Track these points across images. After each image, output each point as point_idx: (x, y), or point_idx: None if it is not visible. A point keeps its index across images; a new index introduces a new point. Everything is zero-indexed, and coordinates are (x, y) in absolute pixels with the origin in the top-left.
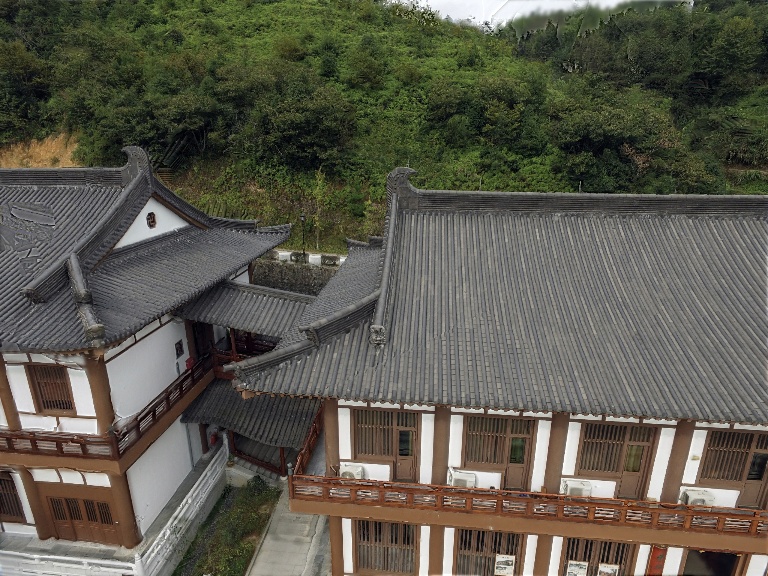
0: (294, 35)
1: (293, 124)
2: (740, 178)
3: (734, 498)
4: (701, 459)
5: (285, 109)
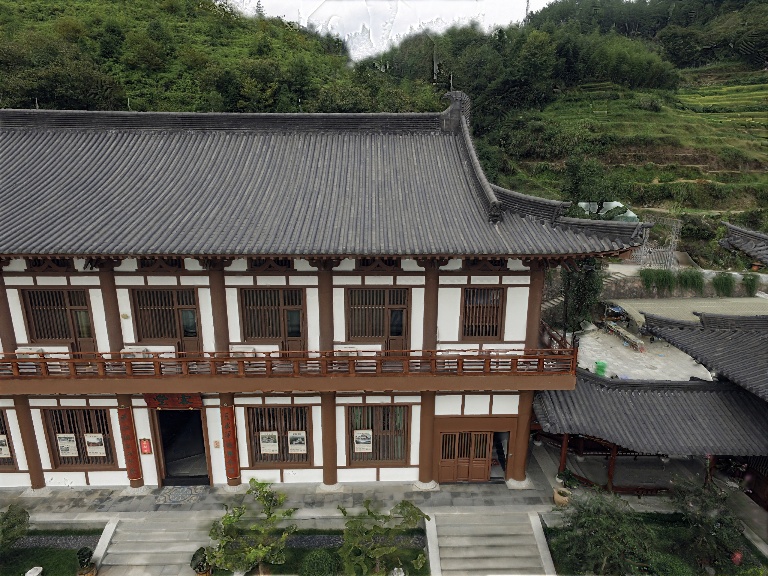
0: (82, 18)
1: (24, 90)
2: (534, 169)
3: (172, 354)
4: (132, 317)
5: (24, 78)
